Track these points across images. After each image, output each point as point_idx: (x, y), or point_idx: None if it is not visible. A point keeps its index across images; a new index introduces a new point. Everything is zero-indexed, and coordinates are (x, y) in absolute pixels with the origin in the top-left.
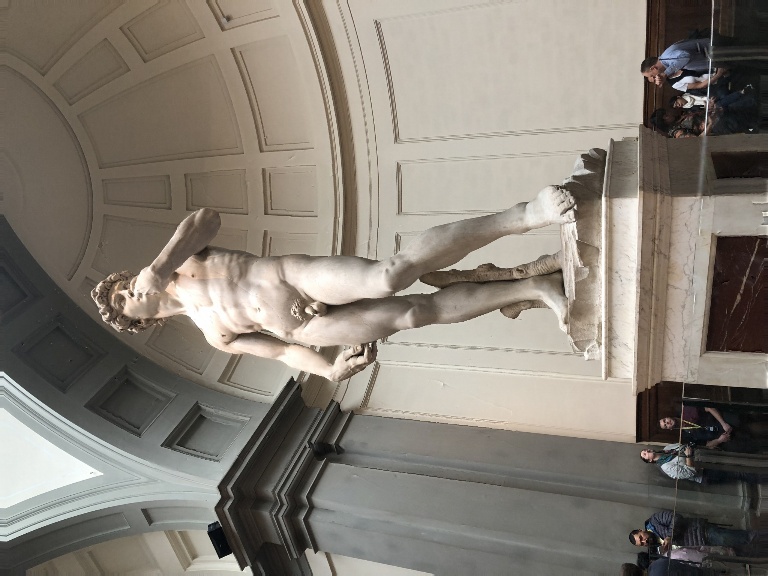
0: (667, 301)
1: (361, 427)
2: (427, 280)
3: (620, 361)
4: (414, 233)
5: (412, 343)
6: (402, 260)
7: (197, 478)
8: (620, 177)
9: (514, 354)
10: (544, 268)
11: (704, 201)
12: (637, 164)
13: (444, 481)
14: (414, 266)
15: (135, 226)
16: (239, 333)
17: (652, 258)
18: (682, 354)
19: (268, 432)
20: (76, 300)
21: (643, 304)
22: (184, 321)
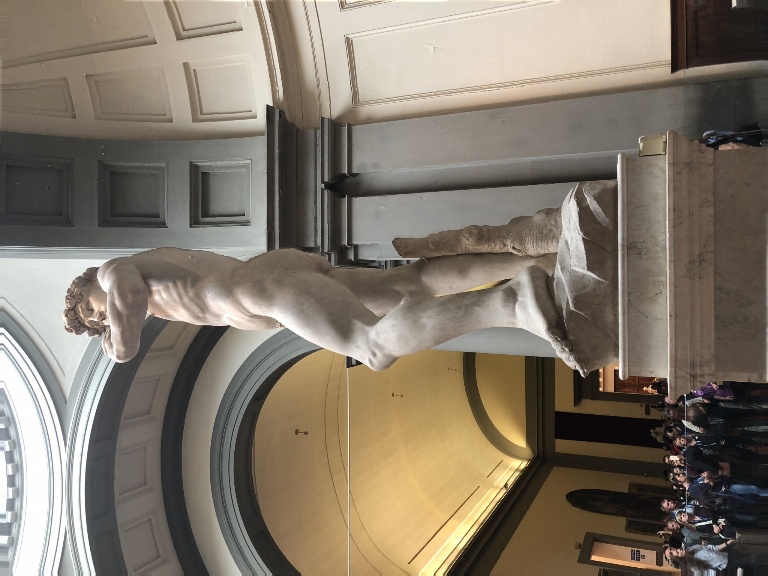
0: None
1: (365, 143)
2: None
3: None
4: None
5: None
6: (383, 353)
7: (241, 247)
8: (642, 305)
9: None
10: None
11: None
12: (666, 261)
13: (470, 193)
14: None
15: None
16: None
17: None
18: None
19: (279, 188)
20: None
21: None
22: (111, 68)
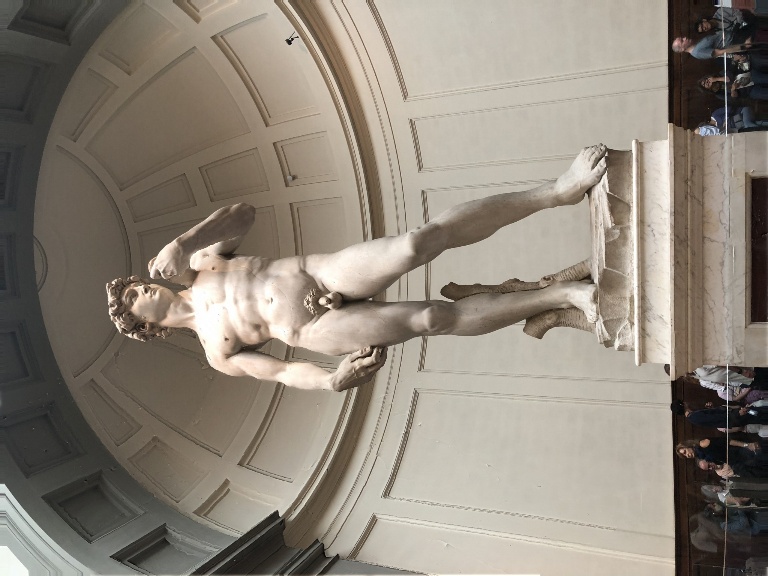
0: (704, 258)
1: (345, 570)
2: (449, 291)
3: (655, 340)
4: (433, 391)
5: (416, 500)
6: (429, 224)
7: None
8: None
9: (531, 520)
10: (572, 273)
11: (735, 138)
12: None
13: None
14: (440, 228)
15: (156, 346)
16: (243, 341)
17: (685, 202)
18: (725, 326)
19: (237, 555)
20: (74, 394)
21: (678, 257)
22: (175, 447)
